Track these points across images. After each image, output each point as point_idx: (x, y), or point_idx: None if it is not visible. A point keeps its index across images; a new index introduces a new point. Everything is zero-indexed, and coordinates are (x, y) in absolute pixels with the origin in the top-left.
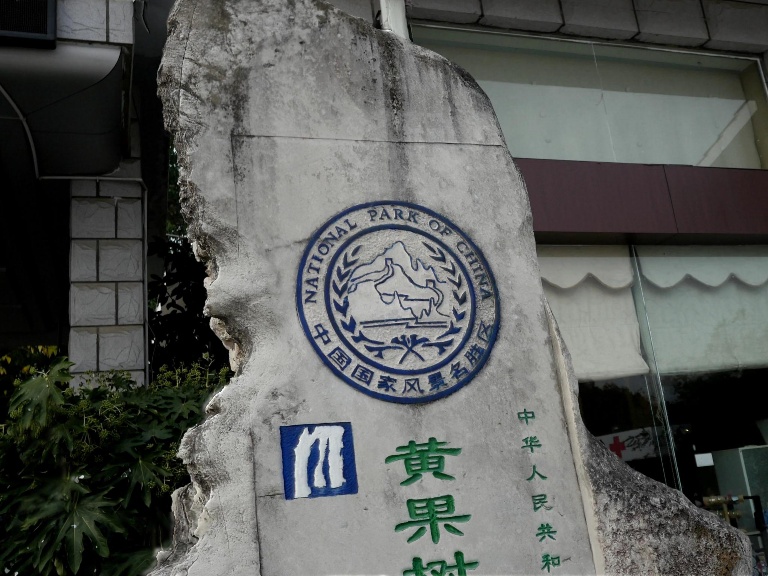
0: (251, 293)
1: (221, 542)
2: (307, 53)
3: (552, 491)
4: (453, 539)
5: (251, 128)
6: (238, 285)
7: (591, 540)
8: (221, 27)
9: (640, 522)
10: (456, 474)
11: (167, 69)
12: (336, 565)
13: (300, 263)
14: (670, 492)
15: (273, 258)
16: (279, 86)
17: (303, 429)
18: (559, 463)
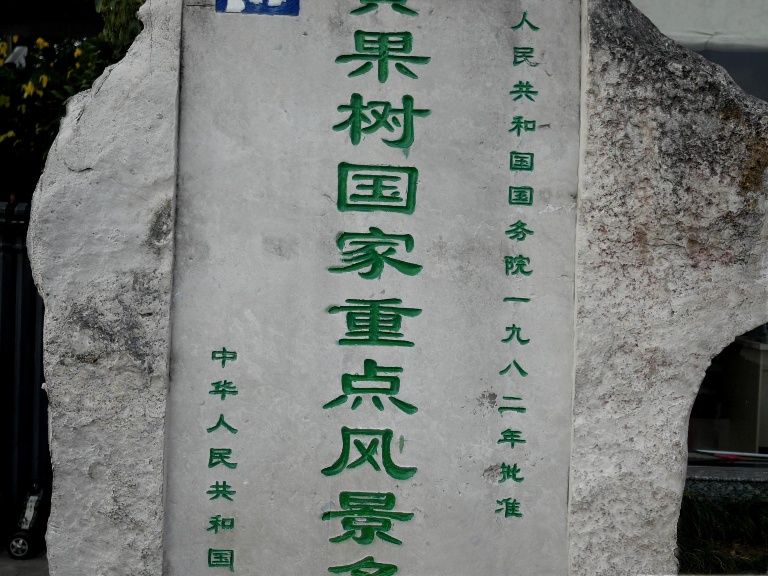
0: None
1: (145, 48)
2: None
3: (542, 45)
4: (403, 80)
5: None
6: None
7: (581, 108)
8: None
9: (647, 90)
10: (420, 9)
11: None
12: (264, 88)
13: None
14: (705, 64)
15: None
16: None
17: None
18: (560, 14)
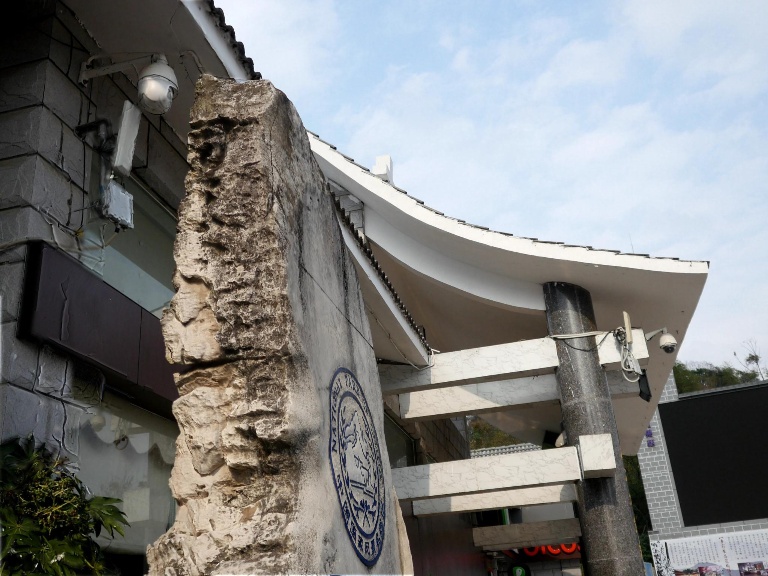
0: (312, 429)
1: None
2: (320, 212)
3: None
4: None
5: (305, 262)
6: (306, 417)
7: None
8: (287, 152)
9: None
10: None
11: (262, 167)
12: None
13: (330, 410)
14: None
15: None
16: (312, 232)
17: None
18: None
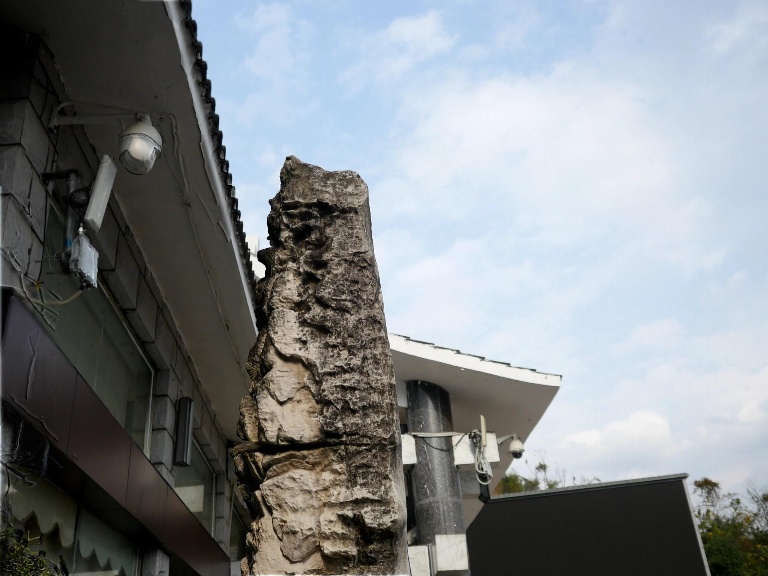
0: None
1: None
2: None
3: None
4: None
5: None
6: None
7: None
8: None
9: None
10: None
11: (370, 257)
12: None
13: None
14: None
15: None
16: None
17: None
18: None
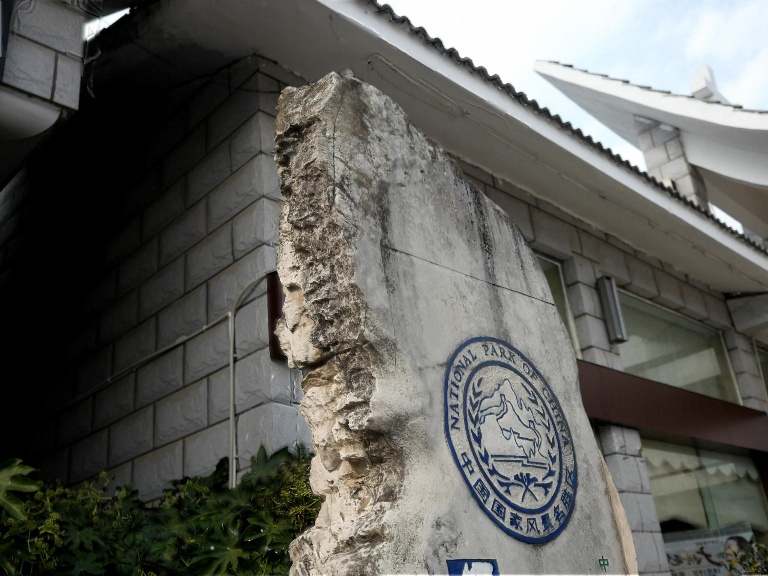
0: (410, 411)
1: None
2: (426, 182)
3: None
4: None
5: (394, 242)
6: (398, 401)
7: None
8: (361, 136)
9: None
10: None
11: (319, 163)
12: None
13: (444, 387)
14: None
15: (425, 378)
16: (410, 207)
17: (464, 564)
18: None
